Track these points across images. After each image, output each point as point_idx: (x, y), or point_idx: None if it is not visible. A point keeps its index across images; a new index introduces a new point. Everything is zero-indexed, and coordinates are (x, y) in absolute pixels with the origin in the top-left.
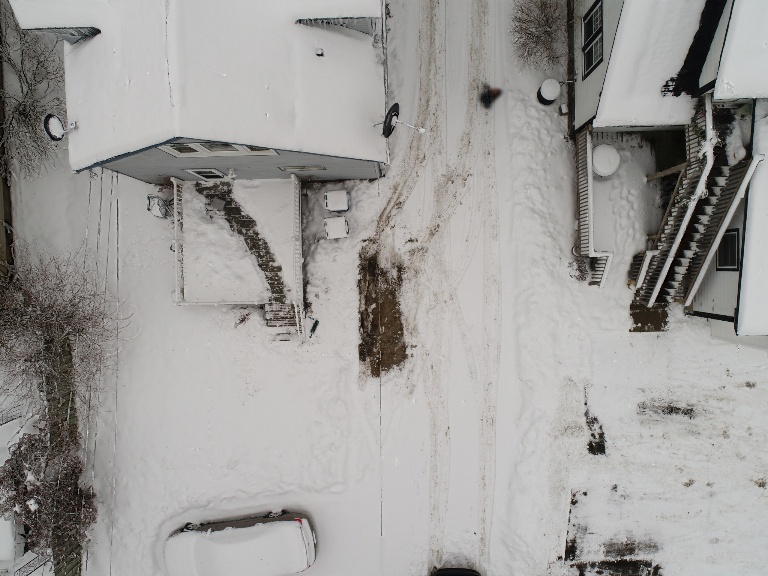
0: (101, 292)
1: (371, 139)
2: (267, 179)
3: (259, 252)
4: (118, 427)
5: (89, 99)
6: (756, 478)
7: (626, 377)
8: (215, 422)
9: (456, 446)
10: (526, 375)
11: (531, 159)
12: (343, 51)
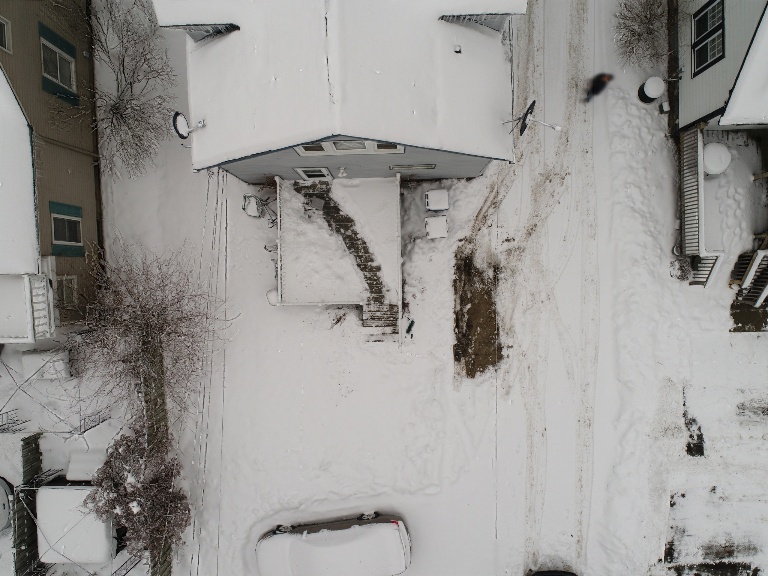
0: (204, 292)
1: (501, 137)
2: (367, 178)
3: (358, 252)
4: (208, 428)
5: (221, 97)
6: None
7: (725, 378)
8: (307, 423)
9: (552, 447)
10: (626, 376)
11: (631, 158)
12: (478, 48)
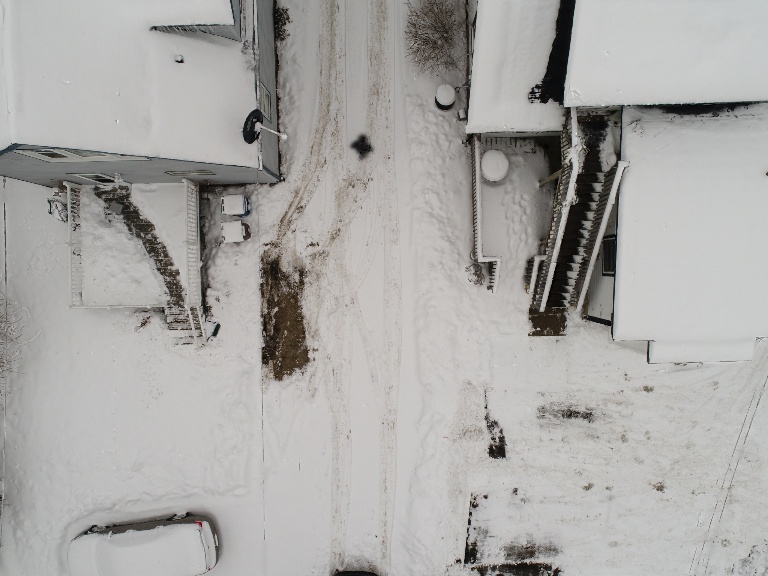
0: None
1: (239, 145)
2: (164, 183)
3: (158, 256)
4: (24, 430)
5: None
6: (654, 482)
7: (526, 381)
8: (120, 425)
9: (358, 449)
10: (425, 379)
11: (429, 164)
12: (206, 57)
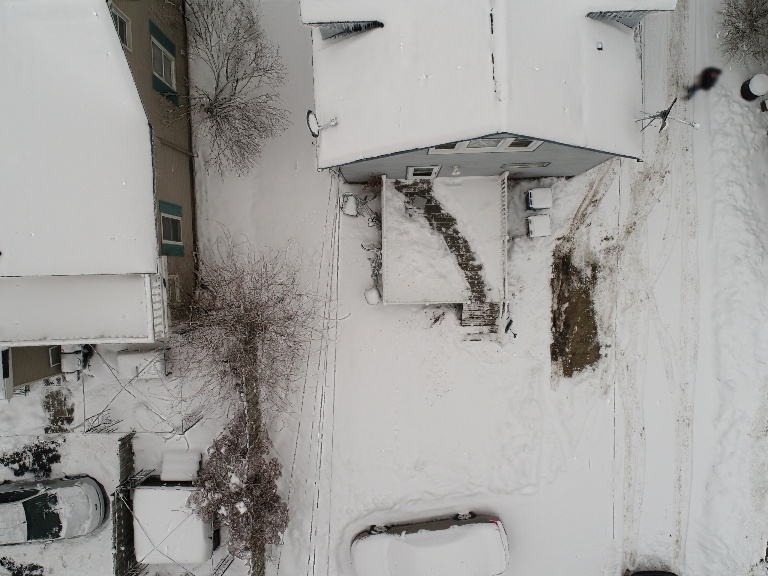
0: (311, 292)
1: (634, 135)
2: (470, 177)
3: (459, 251)
4: (302, 428)
5: (357, 95)
6: None
7: None
8: (402, 423)
9: (651, 447)
10: (727, 375)
11: (734, 156)
12: (616, 45)
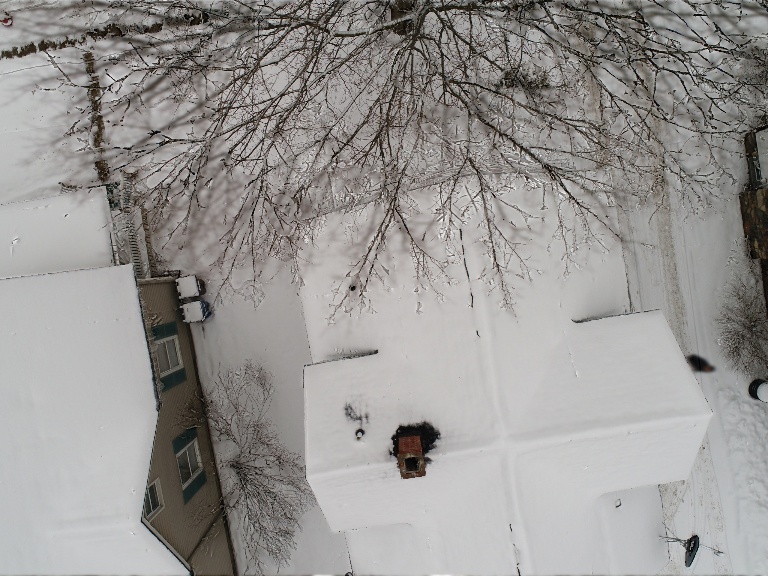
0: None
1: (660, 552)
2: None
3: None
4: None
5: (391, 568)
6: None
7: None
8: None
9: None
10: None
11: (750, 453)
12: None
